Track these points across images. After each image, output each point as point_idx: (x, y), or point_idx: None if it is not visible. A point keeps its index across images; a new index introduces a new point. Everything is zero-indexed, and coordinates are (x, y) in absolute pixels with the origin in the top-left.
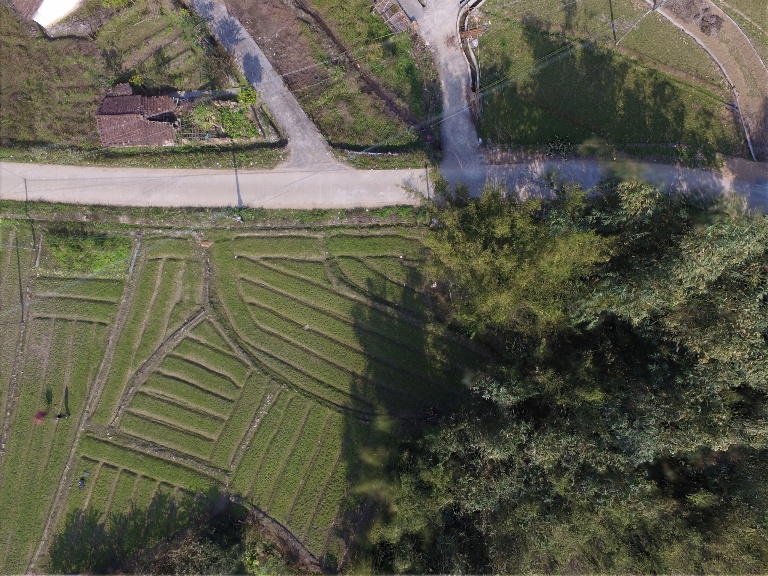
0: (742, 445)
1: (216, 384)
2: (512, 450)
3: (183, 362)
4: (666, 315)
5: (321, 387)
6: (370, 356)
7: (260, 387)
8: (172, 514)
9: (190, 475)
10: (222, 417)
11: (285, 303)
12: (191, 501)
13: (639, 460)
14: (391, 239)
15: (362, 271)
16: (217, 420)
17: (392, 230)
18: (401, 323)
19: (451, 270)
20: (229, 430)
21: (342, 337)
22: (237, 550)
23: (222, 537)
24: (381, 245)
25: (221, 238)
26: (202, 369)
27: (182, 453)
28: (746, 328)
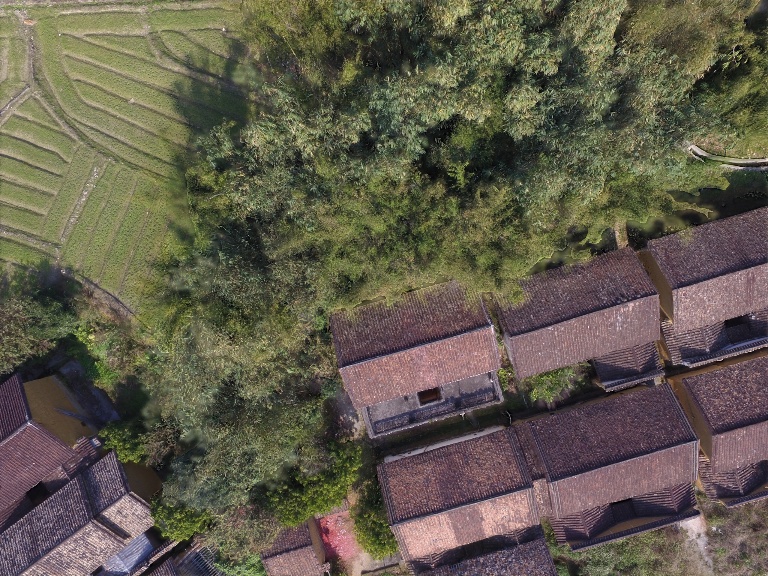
0: (520, 143)
1: (44, 159)
2: (272, 132)
3: (11, 139)
4: (427, 1)
5: (147, 159)
6: (195, 127)
7: (87, 160)
8: (5, 288)
9: (21, 249)
10: (51, 192)
11: (109, 77)
12: (23, 274)
13: (406, 147)
14: (212, 11)
15: (185, 44)
16: (46, 195)
17: (213, 2)
18: (224, 93)
19: (243, 3)
20: (58, 204)
21: (166, 109)
22: (60, 308)
23: (45, 297)
24: (203, 17)
25: (44, 16)
26: (29, 145)
27: (13, 229)
28: (500, 2)
